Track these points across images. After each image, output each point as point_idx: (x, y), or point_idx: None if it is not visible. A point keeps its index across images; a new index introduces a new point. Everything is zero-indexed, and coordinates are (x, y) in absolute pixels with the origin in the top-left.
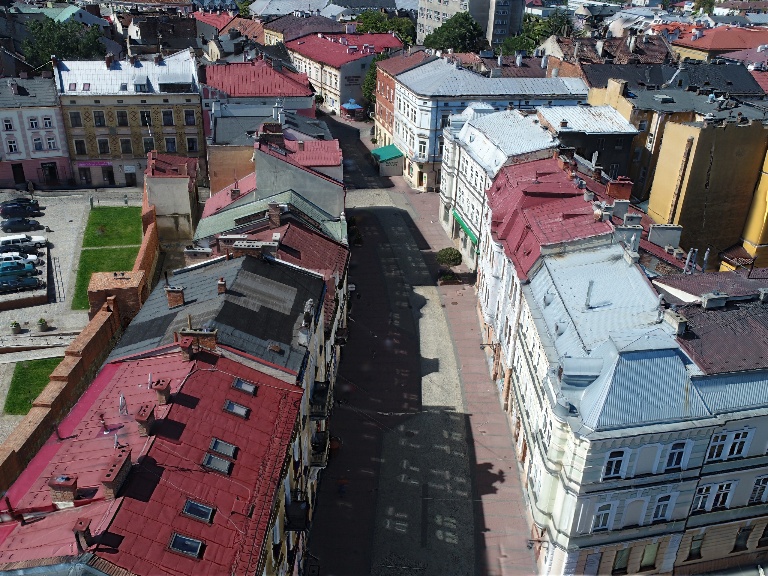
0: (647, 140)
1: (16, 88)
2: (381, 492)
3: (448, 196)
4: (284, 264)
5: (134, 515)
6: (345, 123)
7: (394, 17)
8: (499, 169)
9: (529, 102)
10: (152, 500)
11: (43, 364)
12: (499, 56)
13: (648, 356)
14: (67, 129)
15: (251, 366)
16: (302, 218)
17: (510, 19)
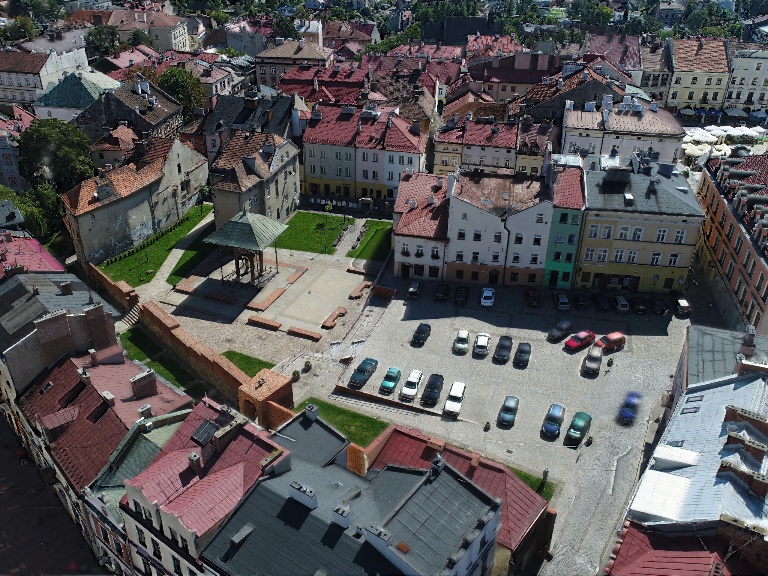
0: None
1: (738, 367)
2: None
3: None
4: None
5: None
6: None
7: None
8: None
9: None
10: None
11: None
12: None
13: None
14: None
15: None
16: None
17: None
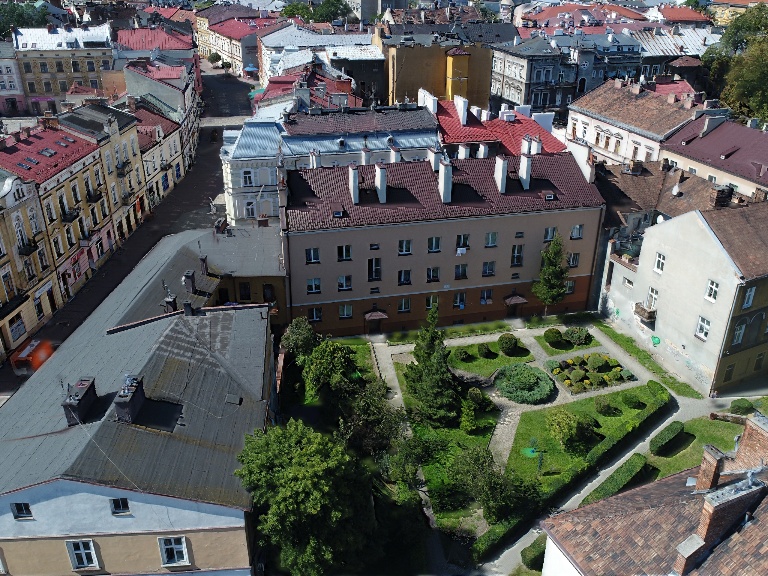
0: None
1: None
2: (169, 231)
3: None
4: (113, 109)
5: (4, 156)
6: (245, 82)
7: (317, 7)
8: None
9: None
10: (13, 155)
11: None
12: (345, 24)
13: (260, 126)
14: (22, 75)
15: (75, 135)
16: (150, 106)
17: (395, 3)
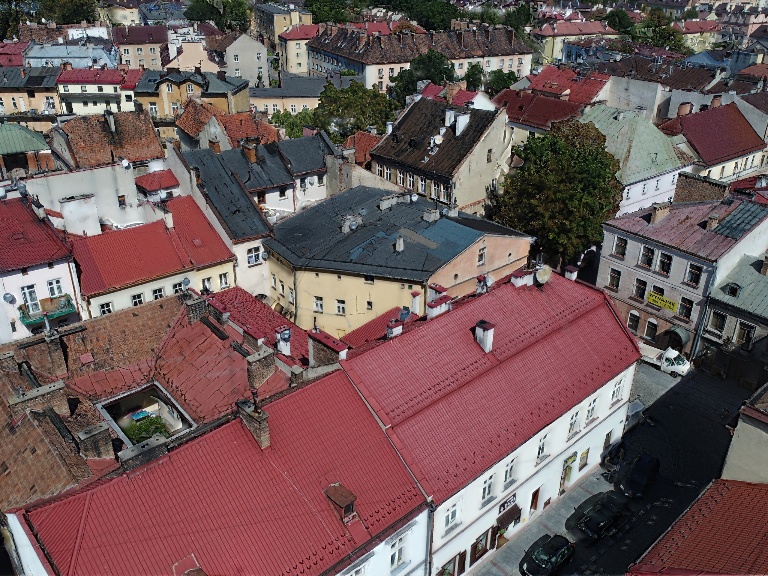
0: None
1: None
2: None
3: None
4: None
5: None
6: None
7: None
8: None
9: None
10: None
11: None
12: None
13: None
14: None
15: None
16: None
17: None
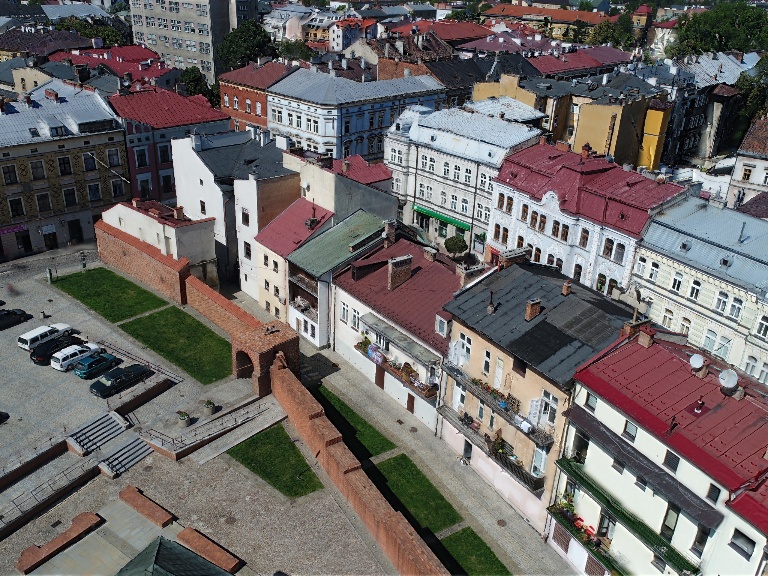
0: (543, 121)
1: None
2: None
3: (404, 194)
4: (536, 264)
5: None
6: None
7: (94, 26)
8: (503, 159)
9: (406, 101)
10: None
11: (256, 443)
12: (330, 61)
13: None
14: None
15: (665, 339)
16: None
17: None
